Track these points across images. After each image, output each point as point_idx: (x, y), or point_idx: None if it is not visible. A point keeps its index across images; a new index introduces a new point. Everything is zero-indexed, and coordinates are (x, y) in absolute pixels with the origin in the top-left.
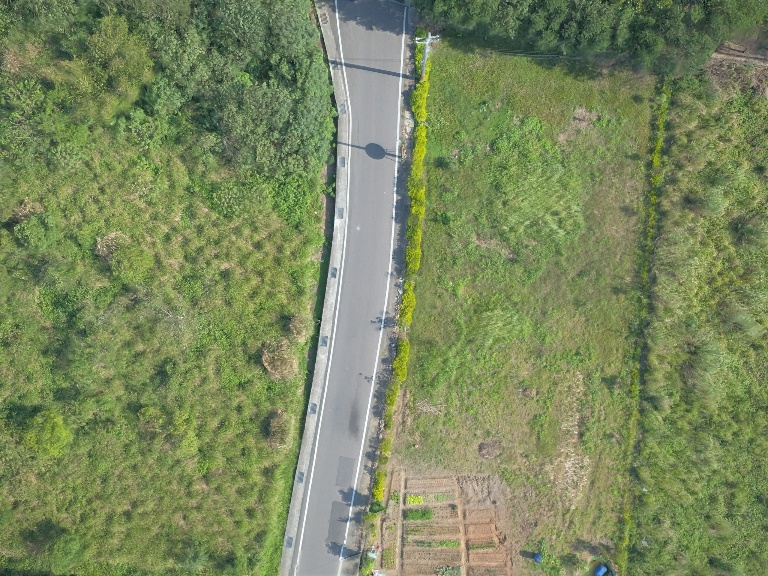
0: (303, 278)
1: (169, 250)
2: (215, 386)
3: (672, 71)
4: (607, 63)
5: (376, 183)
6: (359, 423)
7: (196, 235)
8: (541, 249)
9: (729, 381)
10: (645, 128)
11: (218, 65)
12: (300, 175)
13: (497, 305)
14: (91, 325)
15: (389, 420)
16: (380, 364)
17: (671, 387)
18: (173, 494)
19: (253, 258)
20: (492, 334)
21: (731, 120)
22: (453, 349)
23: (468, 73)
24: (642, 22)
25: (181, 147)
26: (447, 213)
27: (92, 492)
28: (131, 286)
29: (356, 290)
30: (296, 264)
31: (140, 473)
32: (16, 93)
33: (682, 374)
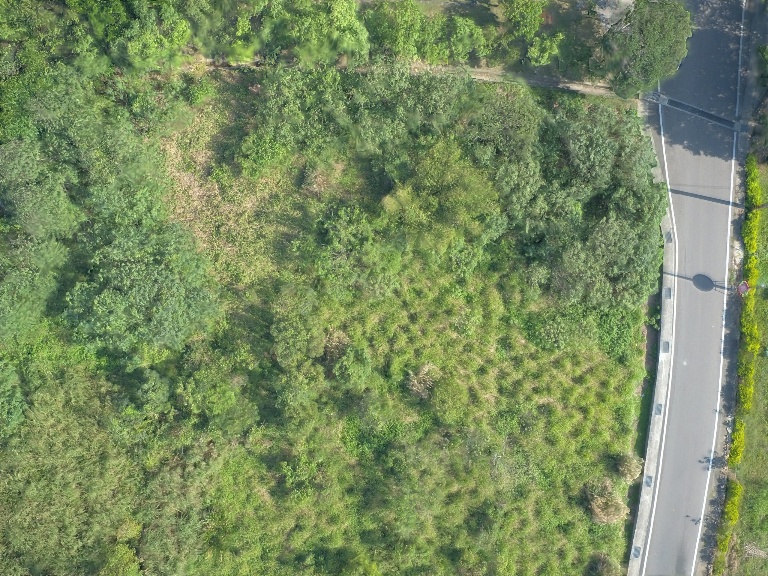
0: (630, 416)
1: (484, 384)
2: (534, 528)
3: None
4: None
5: (704, 316)
6: (686, 568)
7: (513, 368)
8: None
9: None
10: None
11: (560, 197)
12: (625, 307)
13: None
14: (400, 462)
15: (722, 567)
16: (708, 506)
17: None
18: None
19: (576, 394)
20: None
21: None
22: None
23: None
24: None
25: (497, 274)
26: None
27: None
28: None
29: (682, 428)
30: (620, 400)
31: None
32: (343, 223)
33: None
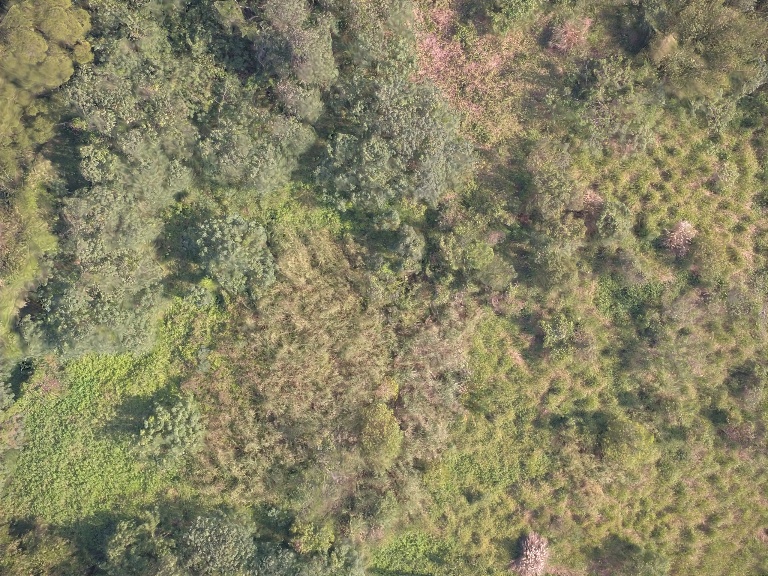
0: None
1: (741, 241)
2: None
3: None
4: None
5: None
6: None
7: None
8: None
9: None
10: None
11: None
12: None
13: None
14: (655, 323)
15: None
16: None
17: None
18: (758, 506)
19: None
20: None
21: None
22: None
23: None
24: None
25: (751, 130)
26: None
27: (661, 505)
28: (704, 280)
29: None
30: None
31: (721, 484)
32: (610, 69)
33: None
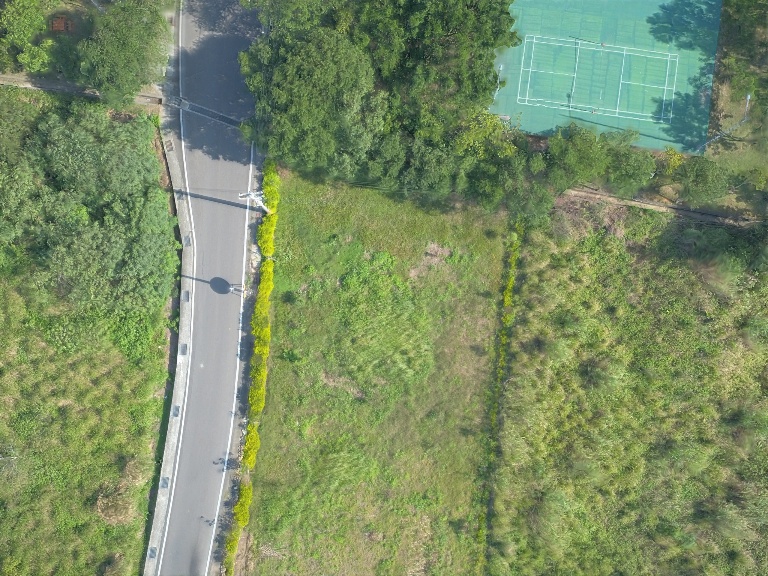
0: (143, 418)
1: (4, 386)
2: (50, 529)
3: (523, 210)
4: (460, 198)
5: (221, 319)
6: (200, 568)
7: (32, 370)
8: (390, 389)
9: (575, 528)
10: (498, 265)
11: (48, 201)
12: None
13: (344, 446)
14: None
15: (229, 567)
16: (222, 507)
17: (518, 533)
18: None
19: (91, 396)
20: (338, 477)
21: (581, 262)
22: (298, 492)
23: (318, 205)
24: (483, 170)
25: (18, 277)
26: (294, 351)
27: None
28: None
29: (199, 430)
30: (136, 402)
31: None
32: None
33: (529, 520)
